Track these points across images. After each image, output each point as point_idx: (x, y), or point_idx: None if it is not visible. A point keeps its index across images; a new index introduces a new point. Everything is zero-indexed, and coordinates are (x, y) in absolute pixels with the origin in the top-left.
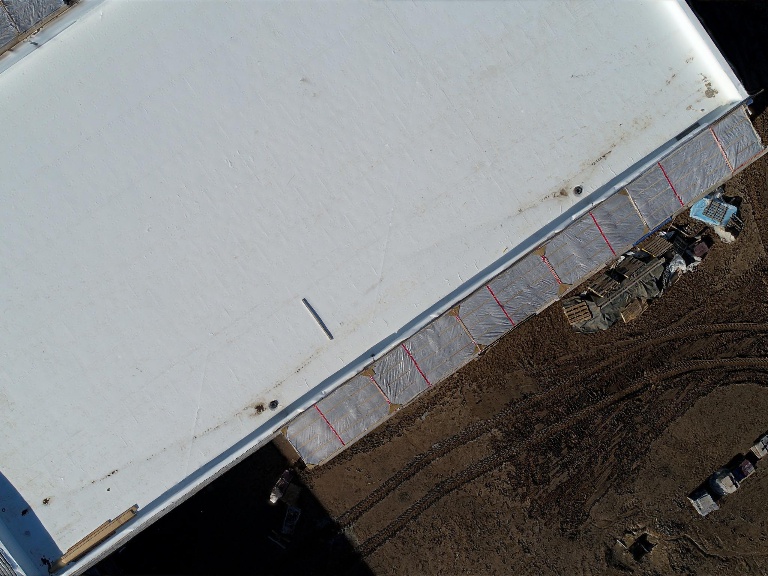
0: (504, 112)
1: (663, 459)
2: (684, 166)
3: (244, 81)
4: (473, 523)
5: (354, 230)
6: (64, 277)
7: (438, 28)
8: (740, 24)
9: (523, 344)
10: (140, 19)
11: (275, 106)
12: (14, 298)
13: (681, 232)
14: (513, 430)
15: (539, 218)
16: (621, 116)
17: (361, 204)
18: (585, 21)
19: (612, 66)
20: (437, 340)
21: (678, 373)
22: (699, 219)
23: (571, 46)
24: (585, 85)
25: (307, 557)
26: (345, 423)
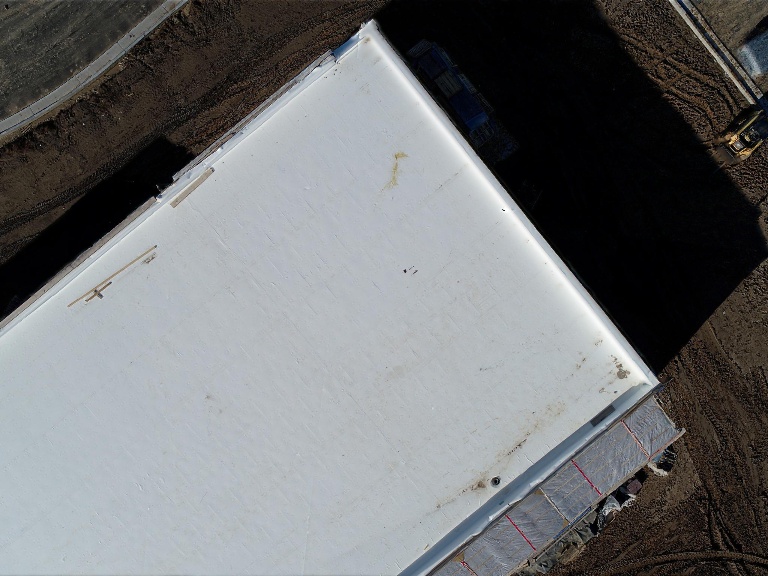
0: (414, 411)
1: None
2: (598, 460)
3: (148, 404)
4: None
5: (272, 541)
6: None
7: (340, 334)
8: (659, 257)
9: None
10: (37, 352)
11: (181, 426)
12: None
13: None
14: None
15: (458, 512)
16: (533, 404)
17: (277, 515)
18: (489, 314)
19: (520, 356)
20: None
21: None
22: None
23: (477, 340)
24: (494, 377)
25: None
26: None
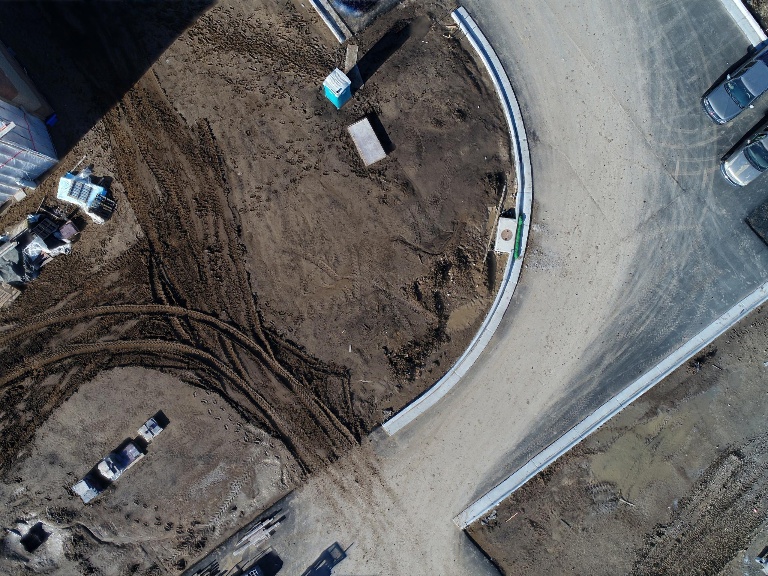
0: None
1: (50, 446)
2: None
3: None
4: None
5: None
6: None
7: None
8: (99, 0)
9: None
10: None
11: None
12: None
13: (51, 214)
14: None
15: None
16: None
17: None
18: None
19: None
20: None
21: (60, 358)
22: (66, 200)
23: None
24: None
25: None
26: None
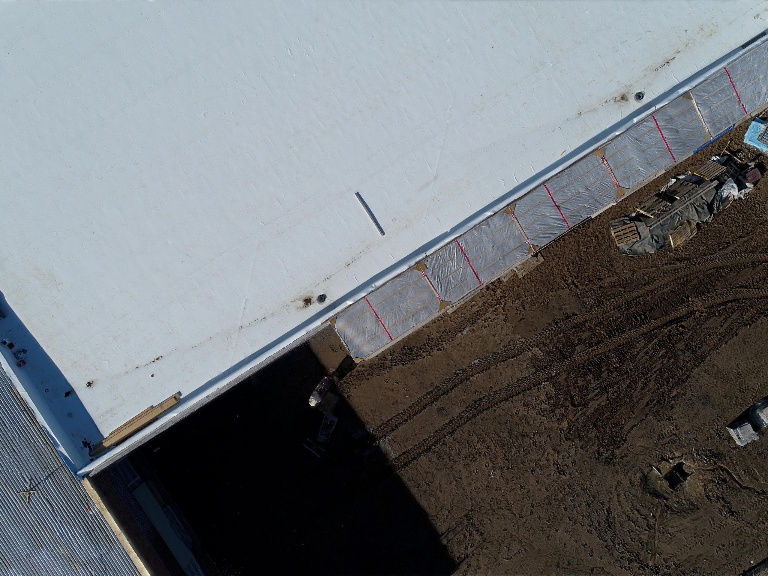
0: (569, 12)
1: (704, 387)
2: (750, 73)
3: None
4: (509, 442)
5: (411, 125)
6: (118, 158)
7: None
8: None
9: (568, 264)
10: None
11: None
12: (67, 177)
13: (734, 158)
14: (554, 350)
15: (598, 122)
16: (687, 22)
17: (419, 99)
18: None
19: None
20: (491, 237)
21: (723, 301)
22: (753, 145)
23: None
24: None
25: (341, 467)
26: (394, 318)
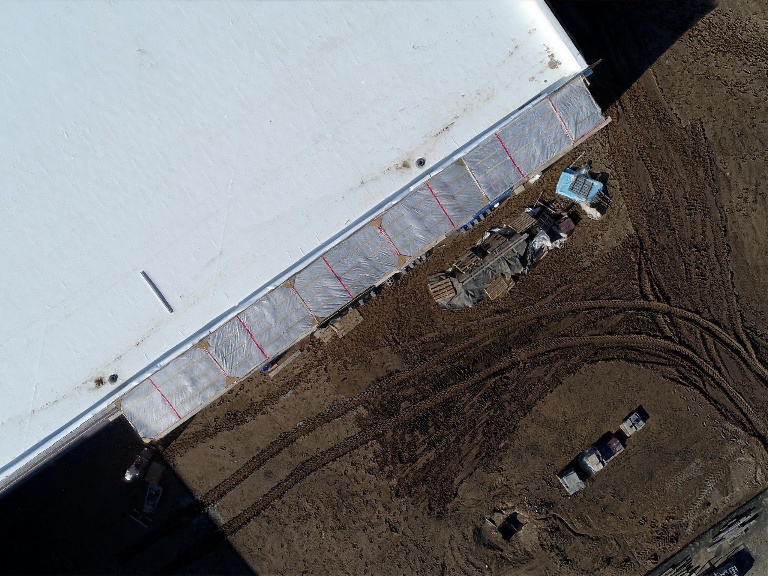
0: (344, 83)
1: (532, 437)
2: (522, 137)
3: (79, 51)
4: (339, 502)
5: (193, 202)
6: None
7: None
8: None
9: (388, 321)
10: None
11: (111, 76)
12: None
13: (548, 208)
14: (379, 408)
15: (381, 190)
16: (463, 87)
17: (200, 176)
18: None
19: (454, 37)
20: (273, 312)
21: (546, 350)
22: (565, 195)
23: (412, 16)
24: (426, 56)
25: (170, 536)
26: (181, 396)
